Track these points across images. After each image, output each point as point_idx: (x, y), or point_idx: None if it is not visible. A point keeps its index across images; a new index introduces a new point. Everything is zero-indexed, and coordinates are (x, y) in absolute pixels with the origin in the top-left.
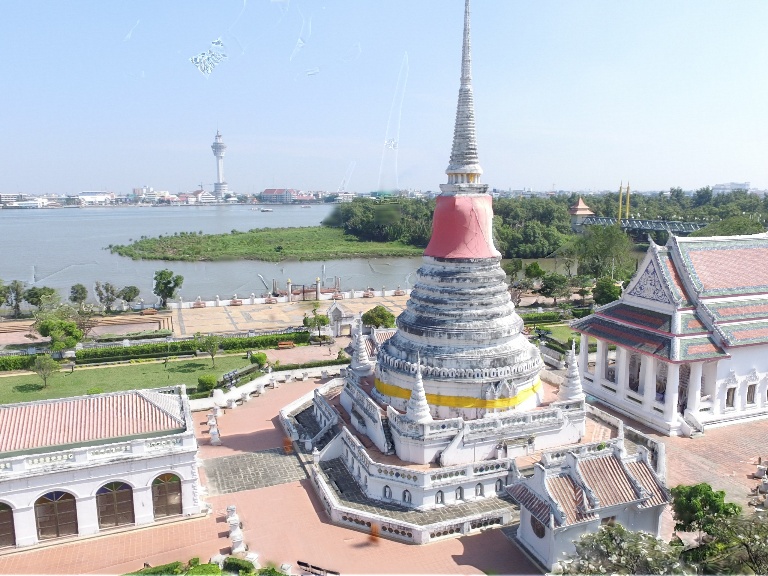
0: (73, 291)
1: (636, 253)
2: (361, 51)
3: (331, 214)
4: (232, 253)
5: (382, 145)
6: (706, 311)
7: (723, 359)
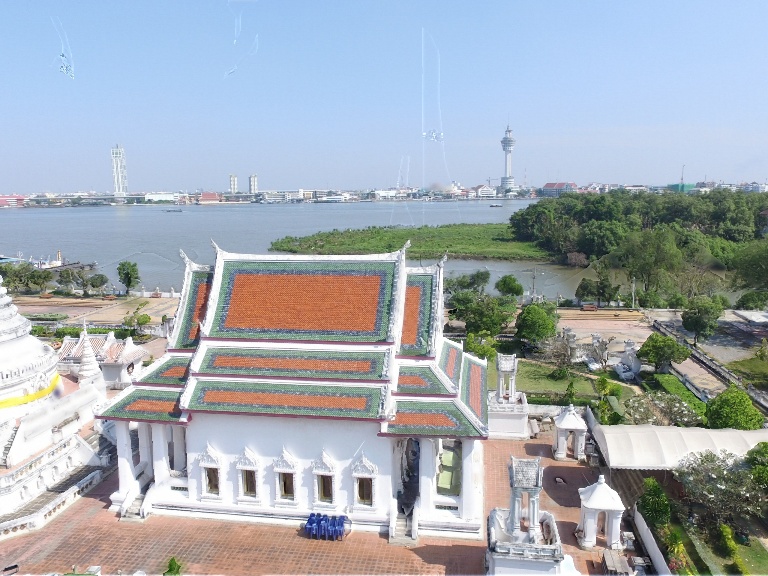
0: (61, 275)
1: (712, 271)
2: (259, 43)
3: (399, 212)
4: (309, 248)
5: (421, 137)
6: (194, 357)
7: (194, 425)
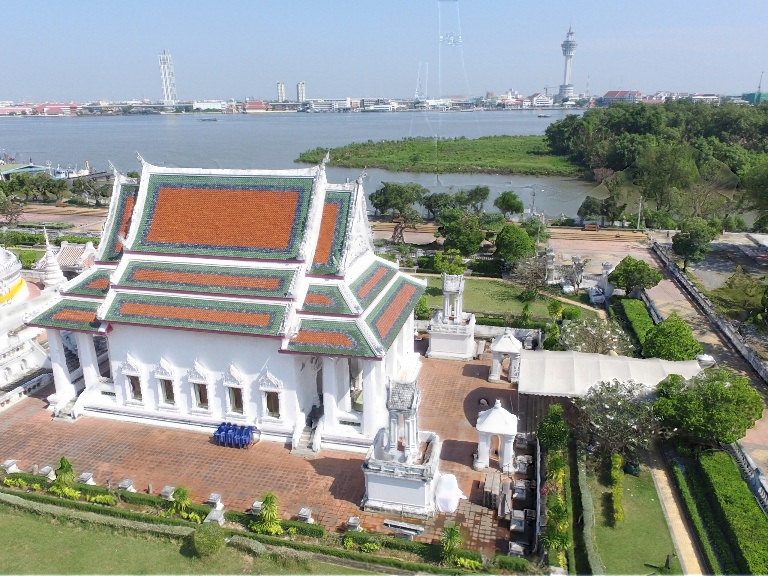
0: (74, 184)
1: (732, 191)
2: None
3: (418, 122)
4: None
5: (438, 41)
6: None
7: (115, 335)
